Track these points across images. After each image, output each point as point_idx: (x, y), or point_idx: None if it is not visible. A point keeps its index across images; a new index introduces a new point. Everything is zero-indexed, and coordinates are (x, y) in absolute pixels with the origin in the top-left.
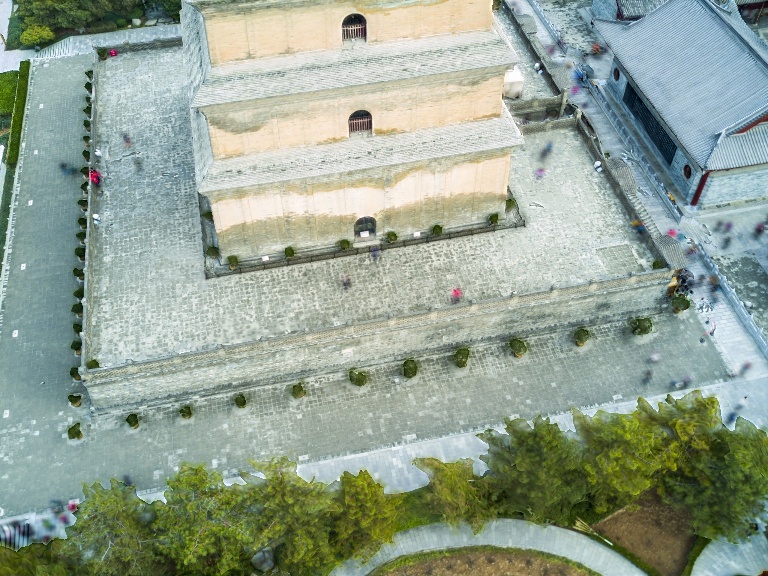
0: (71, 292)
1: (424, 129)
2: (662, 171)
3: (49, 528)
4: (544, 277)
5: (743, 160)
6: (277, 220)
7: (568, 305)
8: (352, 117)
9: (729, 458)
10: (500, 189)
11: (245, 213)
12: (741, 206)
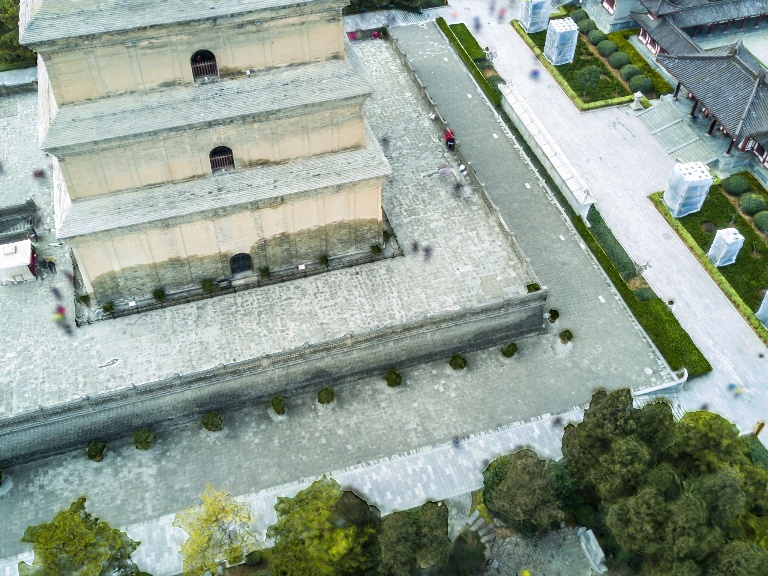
0: None
1: None
2: None
3: (391, 21)
4: None
5: None
6: None
7: None
8: None
9: None
10: None
11: None
12: None
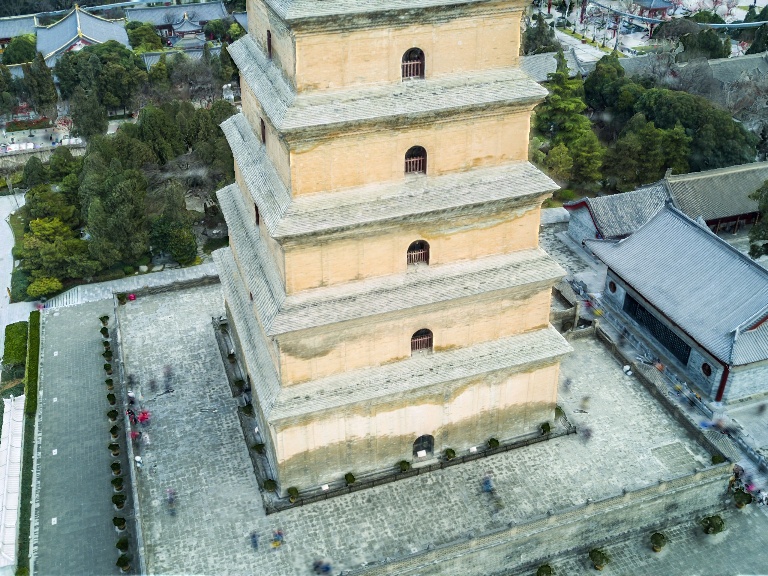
0: (111, 544)
1: (480, 343)
2: (678, 372)
3: None
4: (610, 482)
5: (761, 354)
6: (339, 445)
7: (639, 509)
8: (412, 336)
9: None
10: (550, 397)
11: (309, 440)
12: (762, 399)
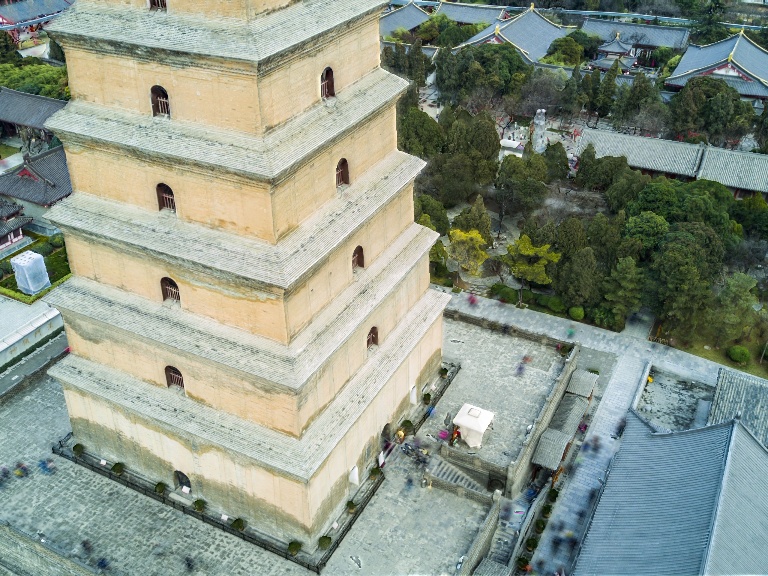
0: None
1: (229, 413)
2: None
3: None
4: None
5: None
6: (112, 432)
7: None
8: None
9: None
10: (301, 517)
11: (88, 411)
12: None
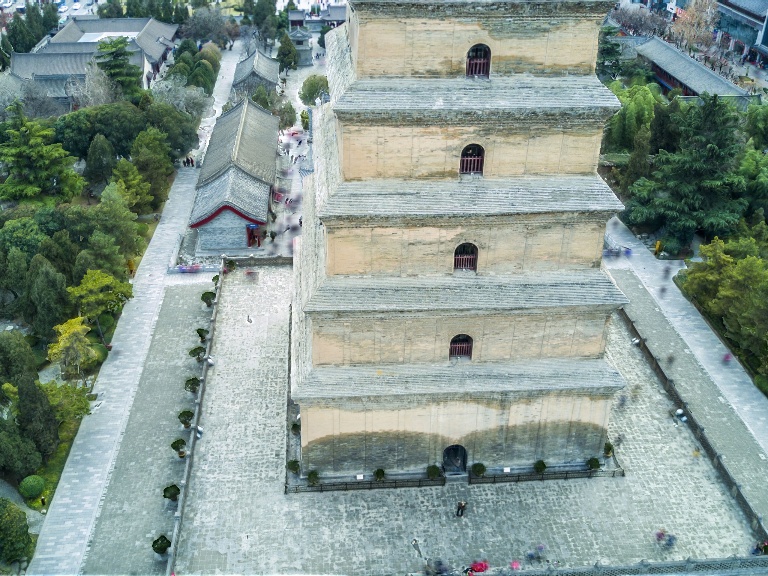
0: None
1: None
2: None
3: None
4: None
5: None
6: None
7: None
8: None
9: (743, 248)
10: None
11: None
12: None
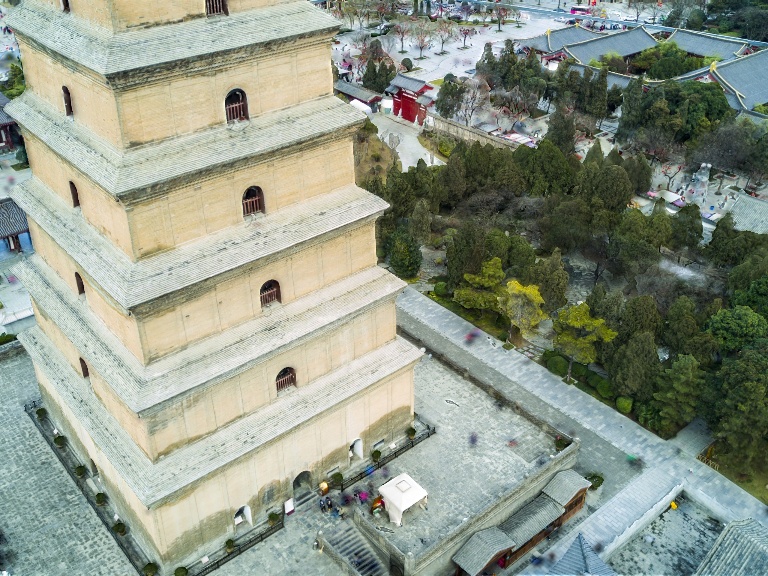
0: None
1: None
2: None
3: None
4: None
5: None
6: None
7: None
8: None
9: None
10: None
11: None
12: None
